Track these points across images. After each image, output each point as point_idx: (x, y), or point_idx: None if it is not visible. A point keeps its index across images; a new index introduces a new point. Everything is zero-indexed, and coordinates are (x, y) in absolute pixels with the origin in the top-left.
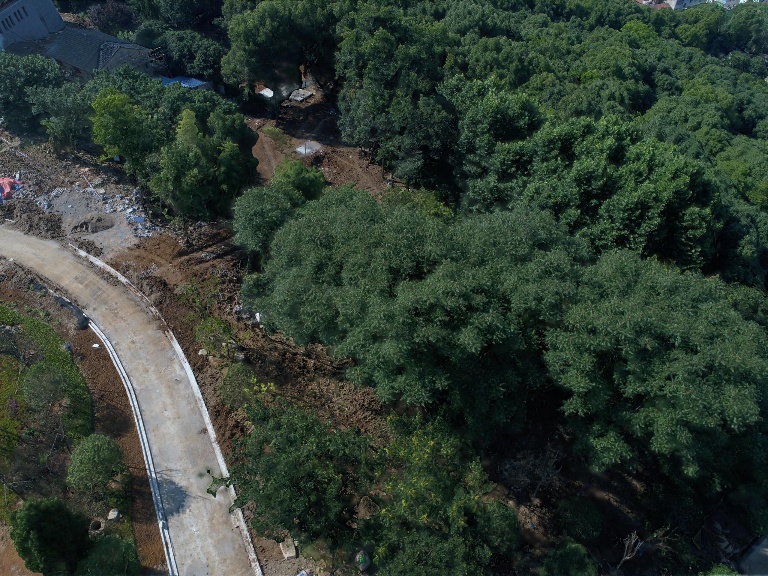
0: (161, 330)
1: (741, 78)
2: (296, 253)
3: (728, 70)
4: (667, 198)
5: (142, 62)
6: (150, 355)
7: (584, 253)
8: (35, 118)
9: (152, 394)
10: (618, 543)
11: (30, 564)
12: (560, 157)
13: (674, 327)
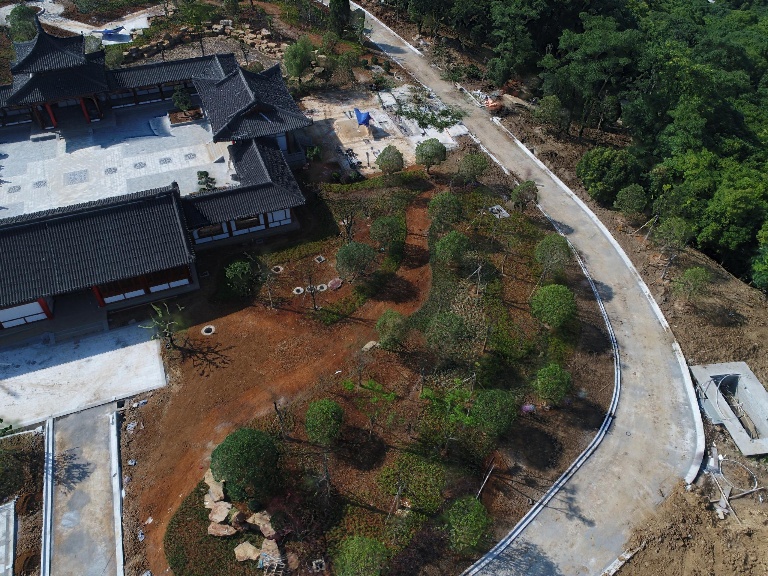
0: None
1: None
2: None
3: None
4: None
5: None
6: None
7: None
8: None
9: None
10: None
11: (338, 6)
12: None
13: None
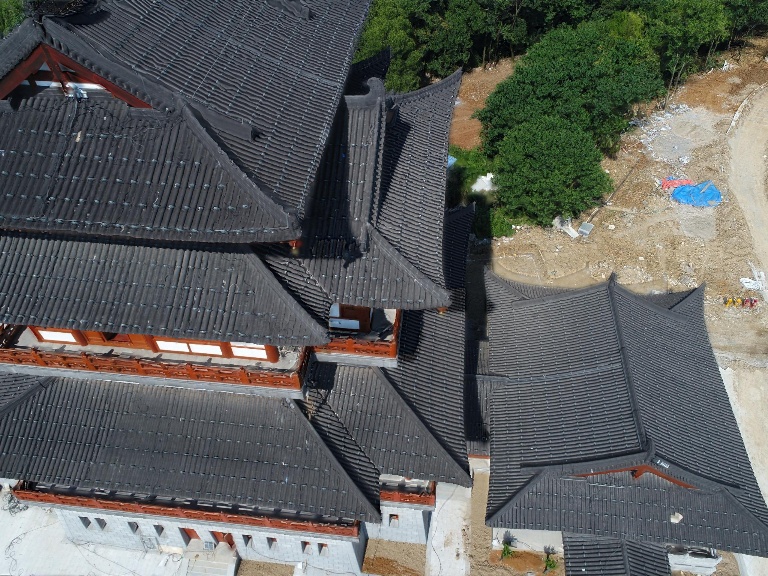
0: None
1: None
2: None
3: None
4: None
5: None
6: None
7: None
8: None
9: None
10: None
11: None
12: None
13: None
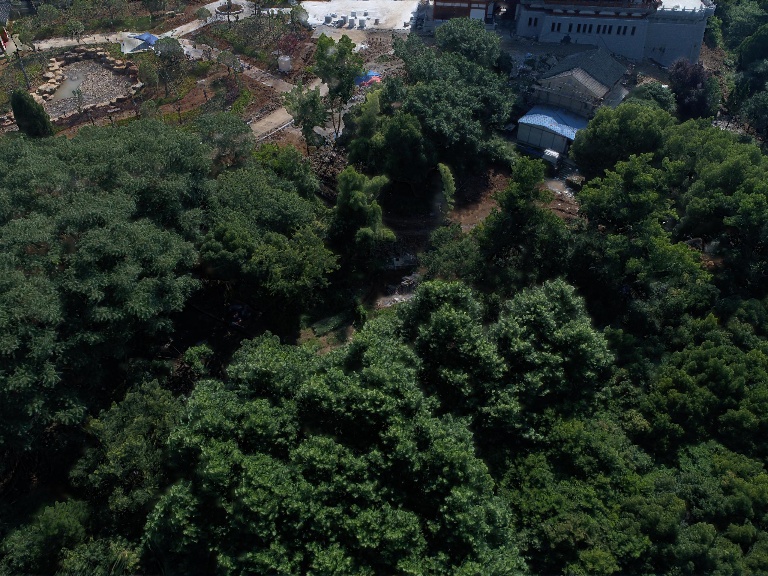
0: None
1: None
2: None
3: None
4: None
5: (579, 99)
6: None
7: (67, 282)
8: None
9: None
10: None
11: None
12: (344, 366)
13: None
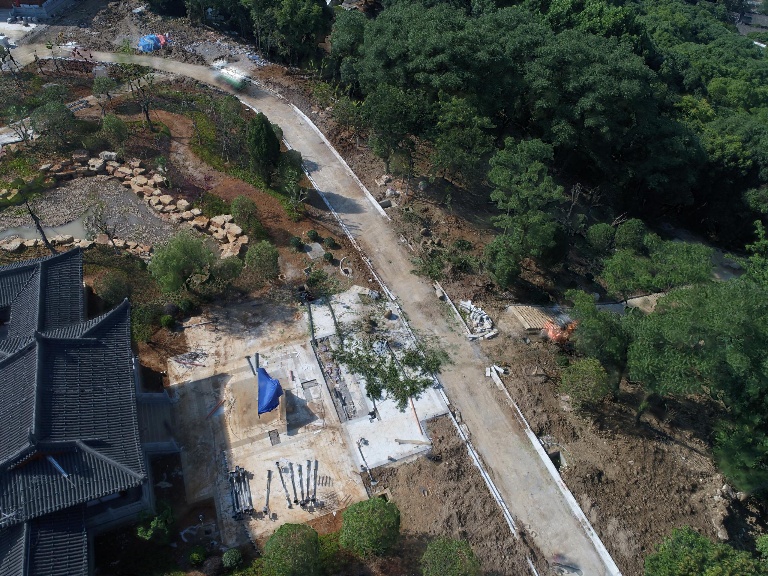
0: (285, 104)
1: (700, 14)
2: (381, 27)
3: (689, 6)
4: (608, 28)
5: None
6: (282, 114)
7: None
8: (170, 3)
9: (287, 129)
10: (571, 212)
11: (258, 149)
12: (541, 13)
13: (595, 51)
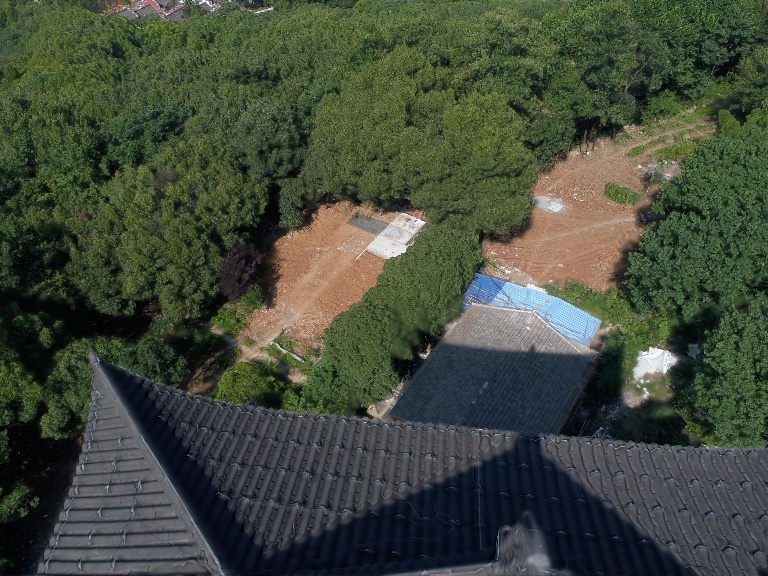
0: None
1: None
2: None
3: None
4: None
5: None
6: None
7: None
8: None
9: None
10: None
11: None
12: None
13: None
